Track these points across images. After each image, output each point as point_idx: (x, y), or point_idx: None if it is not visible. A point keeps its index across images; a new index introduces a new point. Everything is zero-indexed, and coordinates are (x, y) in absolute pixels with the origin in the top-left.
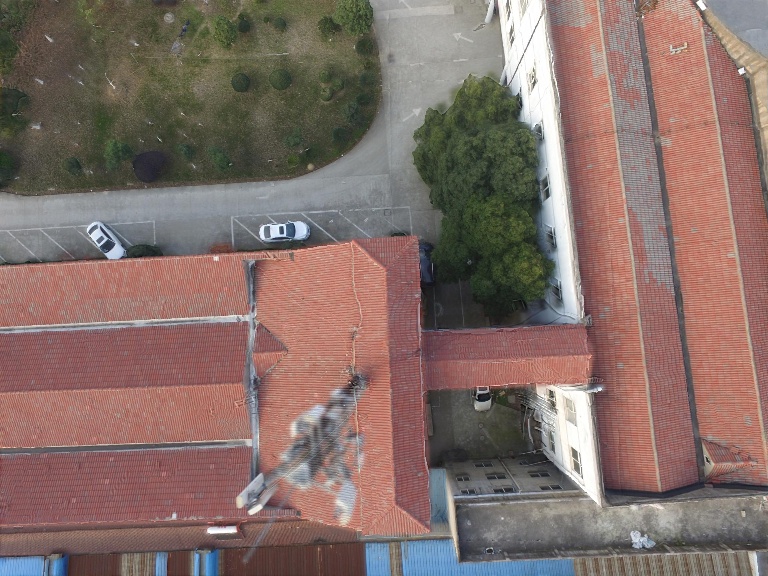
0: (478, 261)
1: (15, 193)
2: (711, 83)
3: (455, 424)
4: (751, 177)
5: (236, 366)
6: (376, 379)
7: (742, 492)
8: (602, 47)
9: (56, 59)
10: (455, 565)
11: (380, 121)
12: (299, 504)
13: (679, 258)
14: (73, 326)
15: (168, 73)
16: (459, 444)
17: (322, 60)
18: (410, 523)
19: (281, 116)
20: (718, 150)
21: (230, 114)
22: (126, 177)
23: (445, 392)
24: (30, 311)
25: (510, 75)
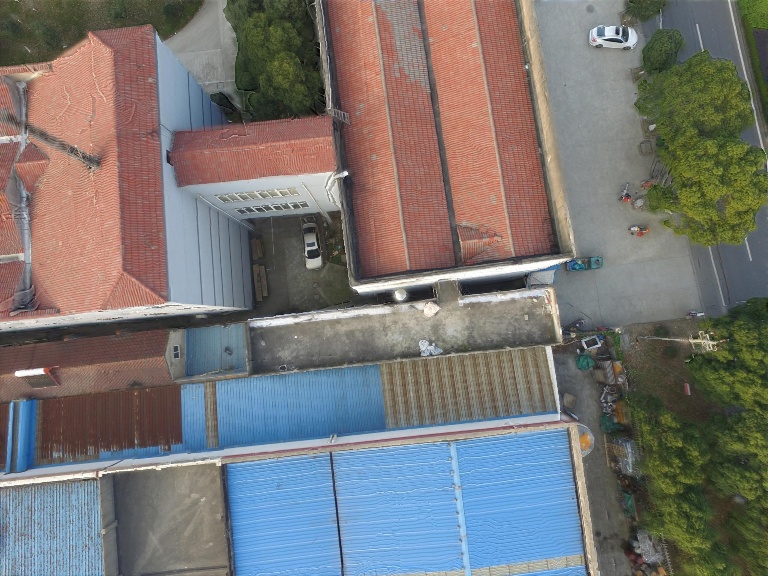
0: None
1: None
2: None
3: (290, 285)
4: None
5: (0, 178)
6: (105, 155)
7: (485, 264)
8: None
9: None
10: (267, 399)
11: None
12: (59, 302)
13: (434, 57)
14: None
15: None
16: (294, 304)
17: None
18: (140, 290)
19: None
20: None
21: None
22: None
23: (279, 255)
24: None
25: None
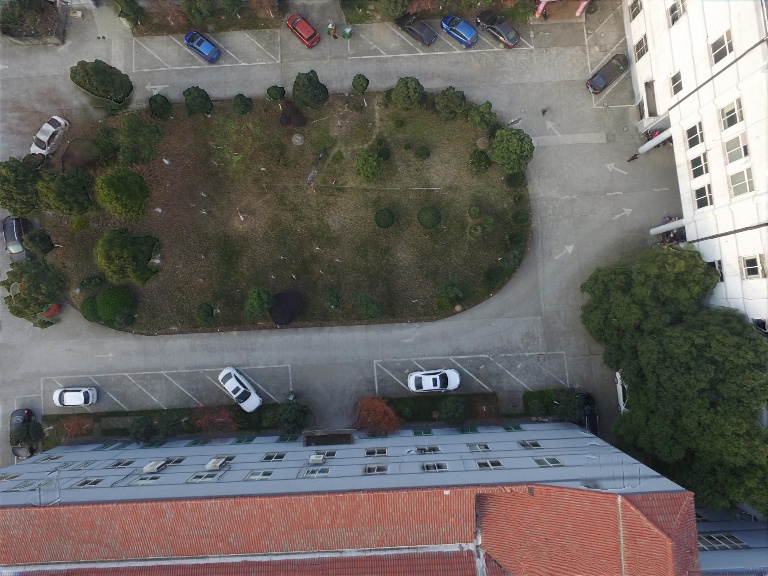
0: (694, 462)
1: (132, 332)
2: None
3: None
4: None
5: None
6: None
7: None
8: None
9: (173, 183)
10: None
11: (531, 258)
12: None
13: None
14: (275, 554)
15: (300, 202)
16: None
17: (468, 191)
18: None
19: (426, 252)
20: None
21: (370, 249)
22: (257, 316)
23: None
24: (230, 541)
25: (695, 235)
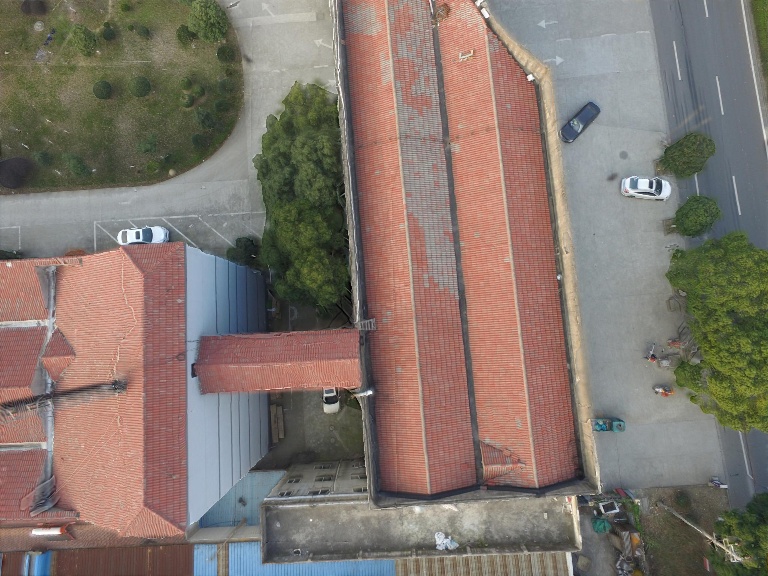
0: (289, 266)
1: None
2: (492, 90)
3: (306, 426)
4: (535, 182)
5: (26, 370)
6: (131, 383)
7: (507, 494)
8: (389, 55)
9: None
10: (280, 566)
11: (241, 127)
12: (79, 506)
13: (464, 262)
14: None
15: (36, 81)
16: (310, 446)
17: (185, 67)
18: (160, 524)
19: (144, 122)
20: (497, 156)
21: (95, 121)
22: None
23: (297, 395)
24: None
25: None
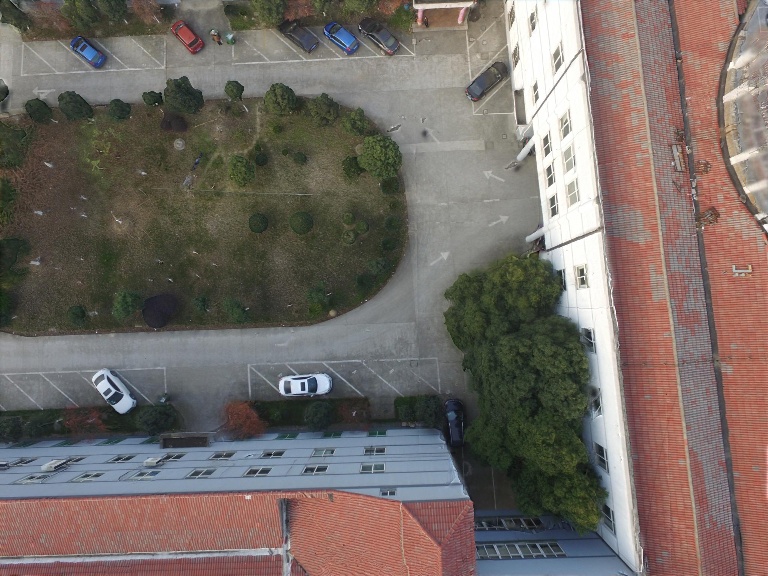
0: (522, 470)
1: (12, 333)
2: None
3: None
4: None
5: None
6: None
7: None
8: (663, 270)
9: (56, 186)
10: None
11: (406, 264)
12: None
13: (739, 495)
14: (89, 555)
15: (179, 206)
16: None
17: (345, 197)
18: None
19: (301, 257)
20: None
21: (246, 253)
22: (134, 319)
23: None
24: (41, 542)
25: (550, 243)
